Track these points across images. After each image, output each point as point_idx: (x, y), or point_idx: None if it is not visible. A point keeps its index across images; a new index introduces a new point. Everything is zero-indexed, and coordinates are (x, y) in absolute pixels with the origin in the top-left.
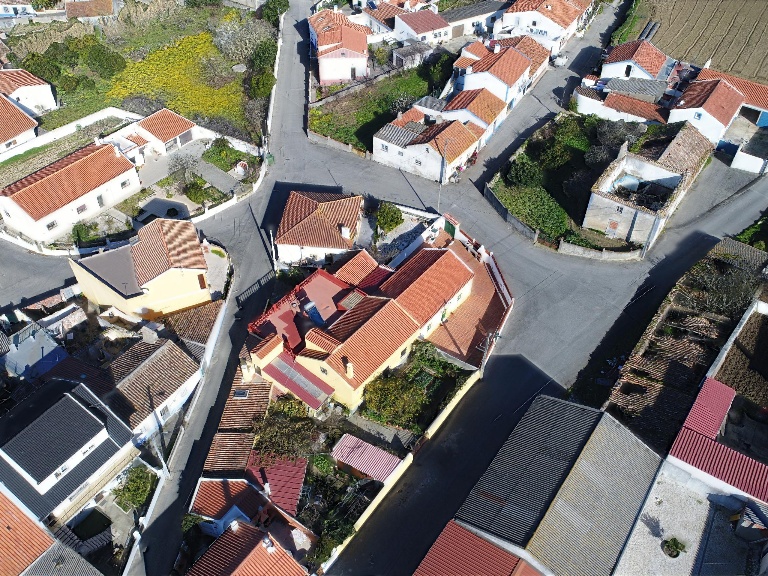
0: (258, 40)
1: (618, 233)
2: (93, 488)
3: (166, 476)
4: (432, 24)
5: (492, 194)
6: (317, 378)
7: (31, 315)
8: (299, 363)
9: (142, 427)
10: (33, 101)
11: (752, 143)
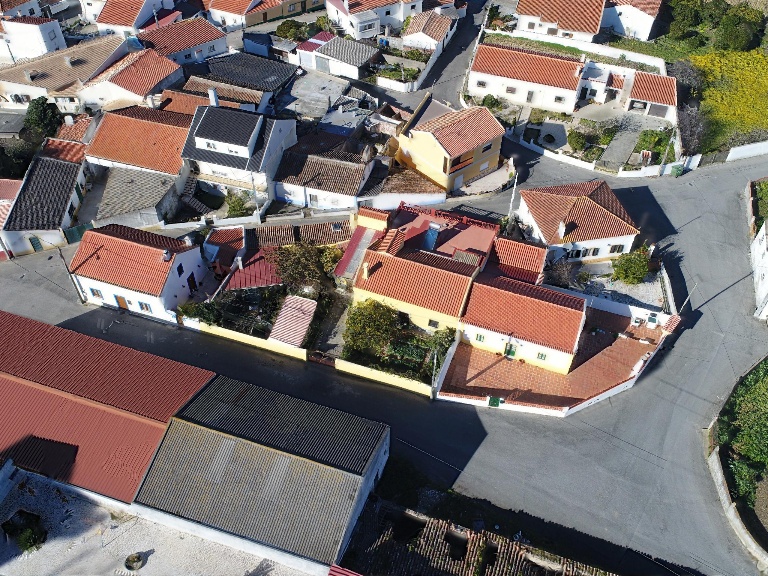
0: None
1: None
2: (222, 177)
3: (258, 220)
4: None
5: None
6: None
7: (390, 113)
8: None
9: (293, 190)
10: (630, 22)
11: None
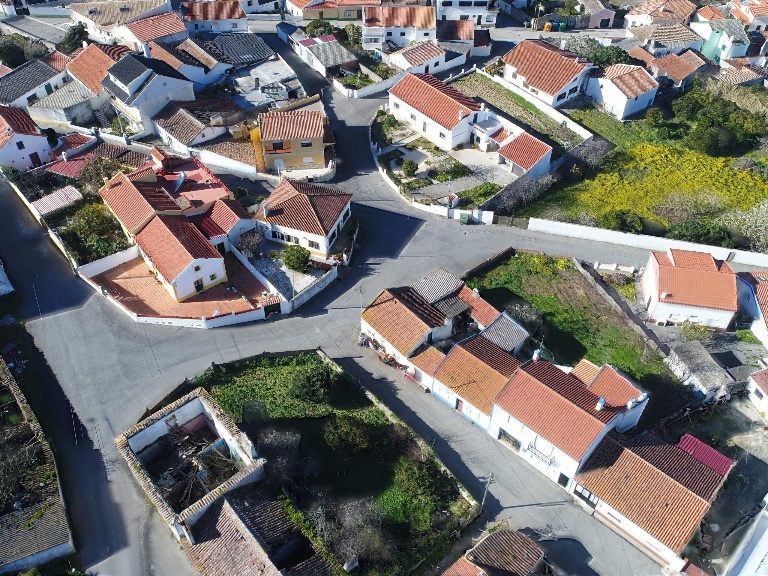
0: (749, 230)
1: None
2: None
3: None
4: None
5: None
6: None
7: None
8: None
9: None
10: (607, 97)
11: None
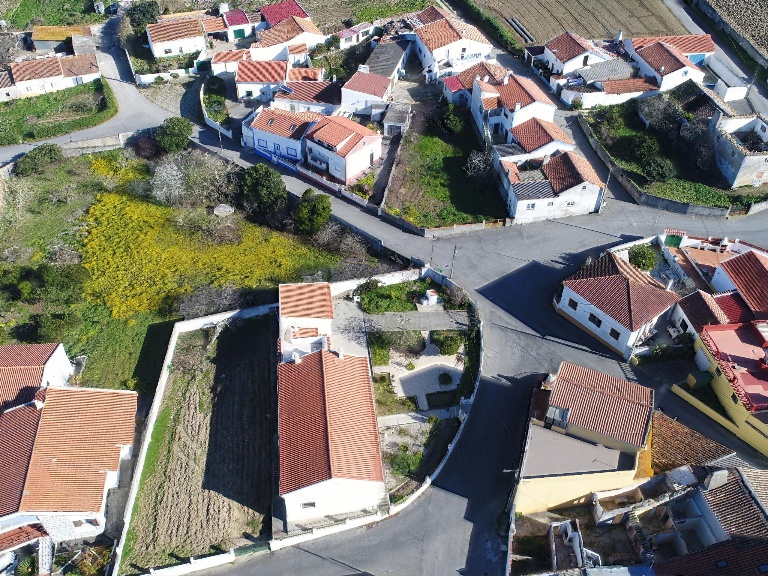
0: (224, 171)
1: (763, 180)
2: None
3: None
4: (379, 84)
5: (658, 198)
6: None
7: (514, 575)
8: None
9: None
10: (61, 375)
11: (704, 80)
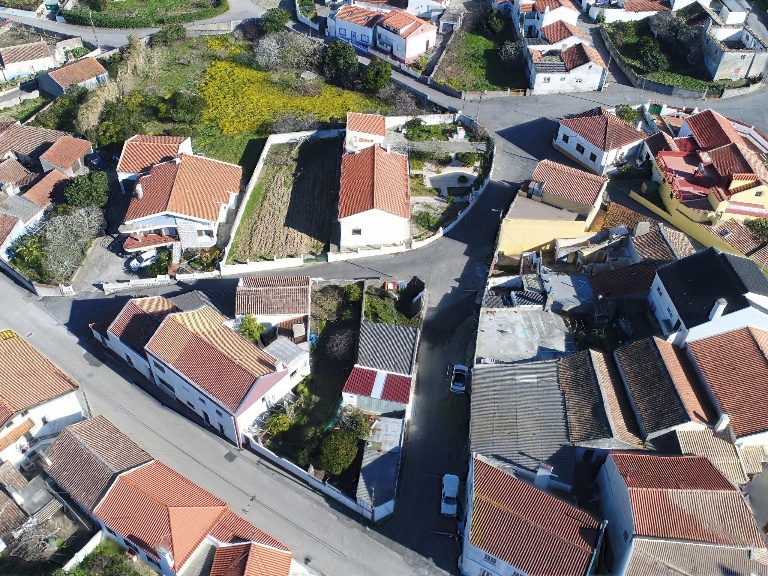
0: (311, 46)
1: (740, 75)
2: None
3: None
4: None
5: (650, 81)
6: (749, 204)
7: None
8: (732, 201)
9: None
10: None
11: None
